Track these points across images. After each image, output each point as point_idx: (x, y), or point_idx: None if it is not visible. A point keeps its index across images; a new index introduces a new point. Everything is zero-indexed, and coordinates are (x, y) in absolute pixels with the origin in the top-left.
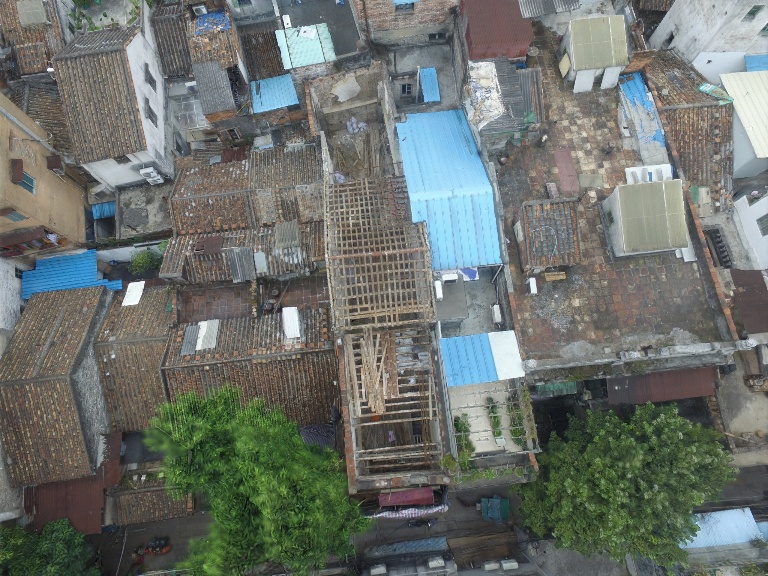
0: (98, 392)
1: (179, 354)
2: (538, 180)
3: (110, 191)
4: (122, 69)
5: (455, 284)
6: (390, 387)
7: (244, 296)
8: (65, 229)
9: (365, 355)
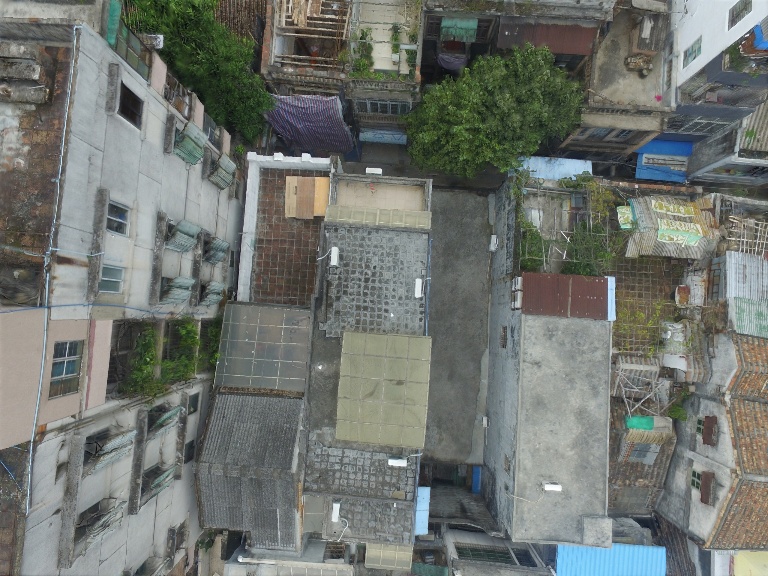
0: None
1: None
2: None
3: None
4: None
5: None
6: (314, 6)
7: None
8: None
9: None
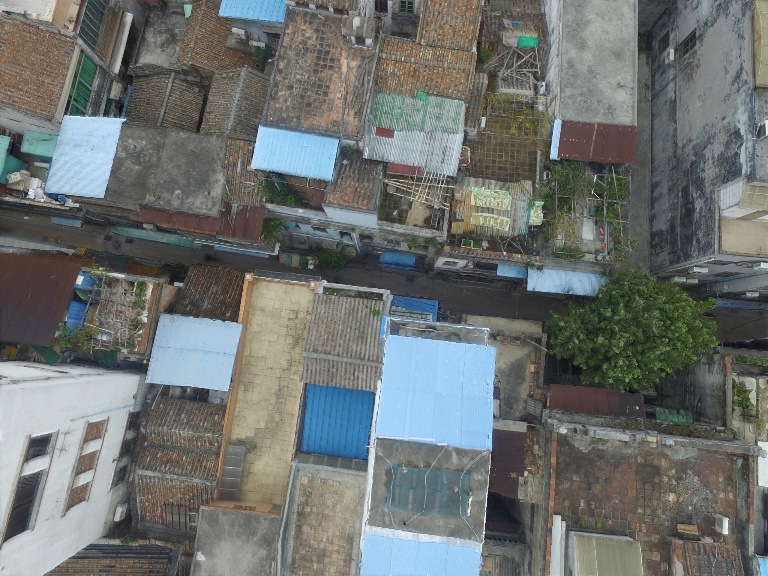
0: None
1: None
2: None
3: None
4: None
5: None
6: None
7: None
8: None
9: None
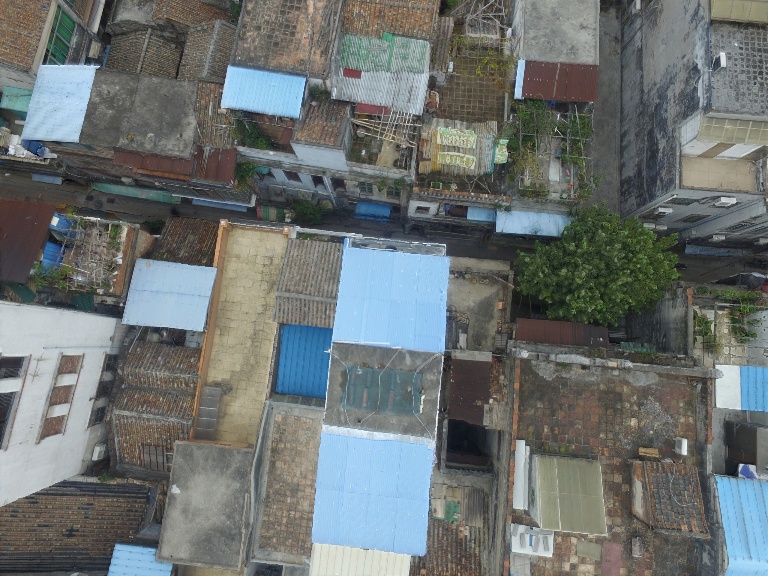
0: None
1: None
2: (644, 564)
3: None
4: None
5: (767, 464)
6: None
7: None
8: None
9: None
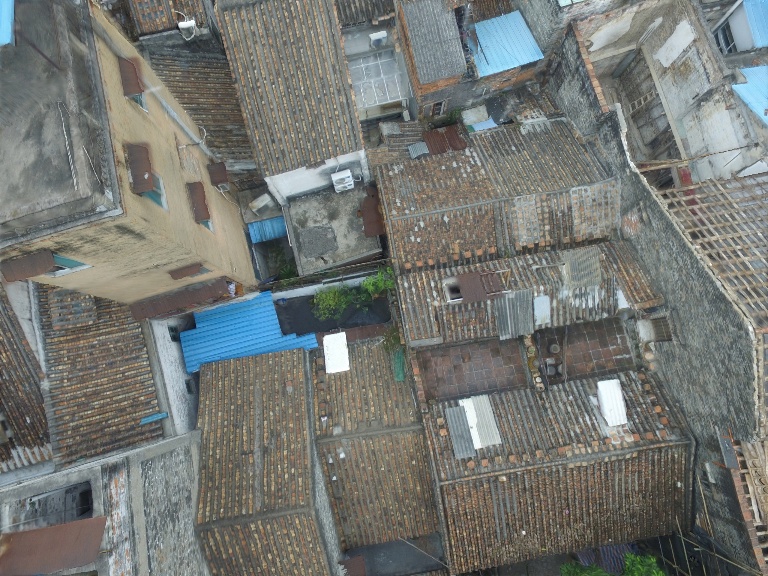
0: (327, 506)
1: (453, 457)
2: None
3: (273, 203)
4: (327, 20)
5: None
6: None
7: (505, 354)
8: (242, 272)
9: (750, 455)
